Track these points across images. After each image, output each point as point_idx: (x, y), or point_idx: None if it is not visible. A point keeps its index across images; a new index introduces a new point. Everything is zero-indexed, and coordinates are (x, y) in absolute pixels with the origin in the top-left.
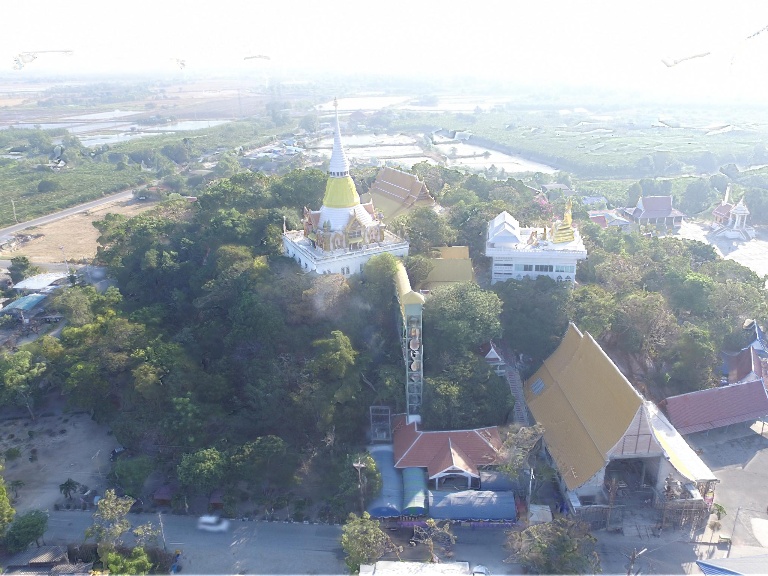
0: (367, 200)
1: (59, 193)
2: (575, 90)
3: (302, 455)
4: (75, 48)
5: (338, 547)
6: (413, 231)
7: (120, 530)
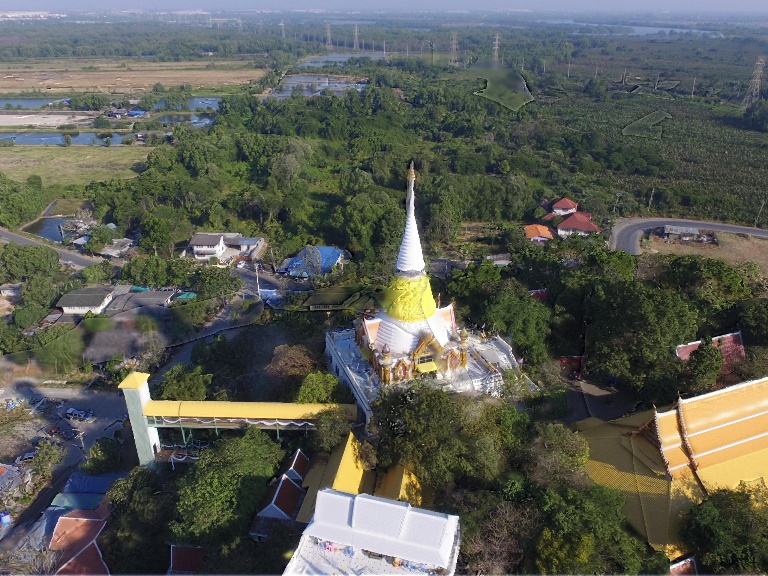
0: None
1: None
2: None
3: None
4: (697, 46)
5: (79, 466)
6: (387, 400)
7: (147, 357)
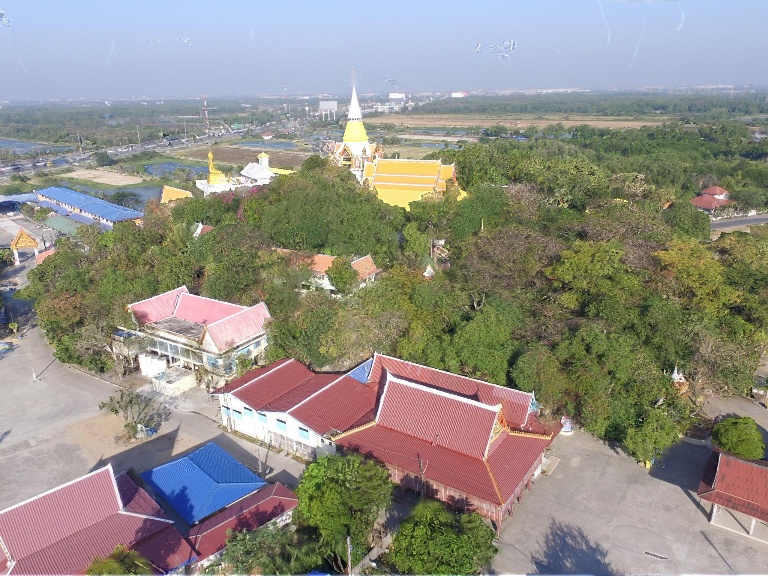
0: None
1: None
2: (208, 70)
3: None
4: None
5: None
6: None
7: None
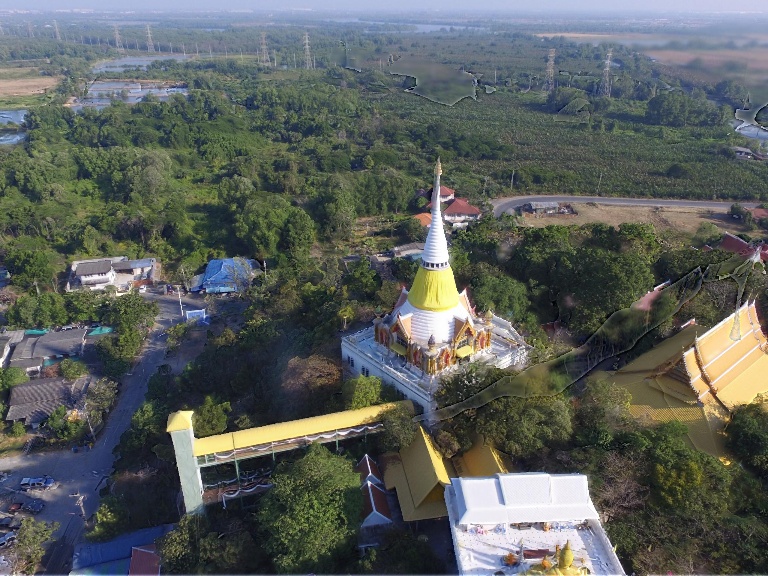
0: (684, 337)
1: (678, 181)
2: None
3: (139, 465)
4: (572, 41)
5: (67, 539)
6: (451, 388)
7: (95, 403)
